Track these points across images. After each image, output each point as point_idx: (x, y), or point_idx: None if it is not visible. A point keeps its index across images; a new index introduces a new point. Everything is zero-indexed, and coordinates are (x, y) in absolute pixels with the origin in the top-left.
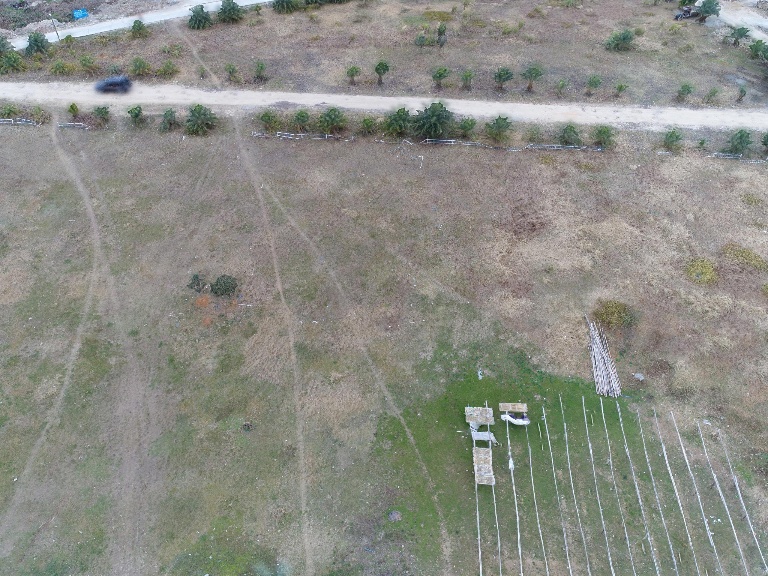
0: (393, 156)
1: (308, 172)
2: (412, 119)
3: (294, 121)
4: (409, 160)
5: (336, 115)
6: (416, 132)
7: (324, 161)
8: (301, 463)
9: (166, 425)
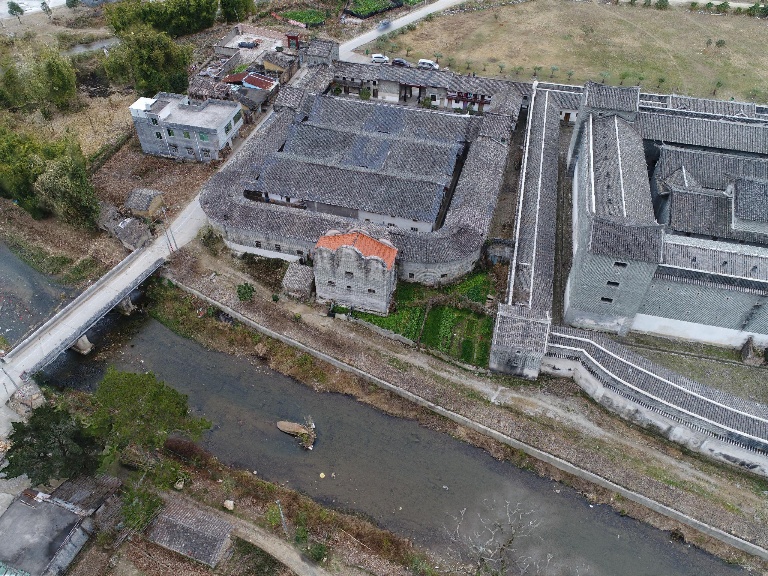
0: (753, 22)
1: (719, 24)
2: (761, 9)
3: (705, 7)
4: (761, 24)
5: (727, 4)
6: (763, 13)
7: (724, 21)
8: (766, 82)
9: (717, 73)
